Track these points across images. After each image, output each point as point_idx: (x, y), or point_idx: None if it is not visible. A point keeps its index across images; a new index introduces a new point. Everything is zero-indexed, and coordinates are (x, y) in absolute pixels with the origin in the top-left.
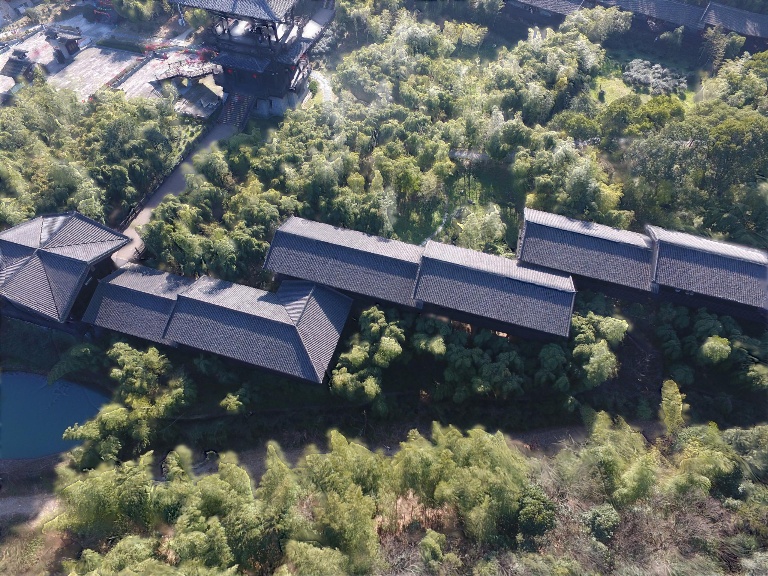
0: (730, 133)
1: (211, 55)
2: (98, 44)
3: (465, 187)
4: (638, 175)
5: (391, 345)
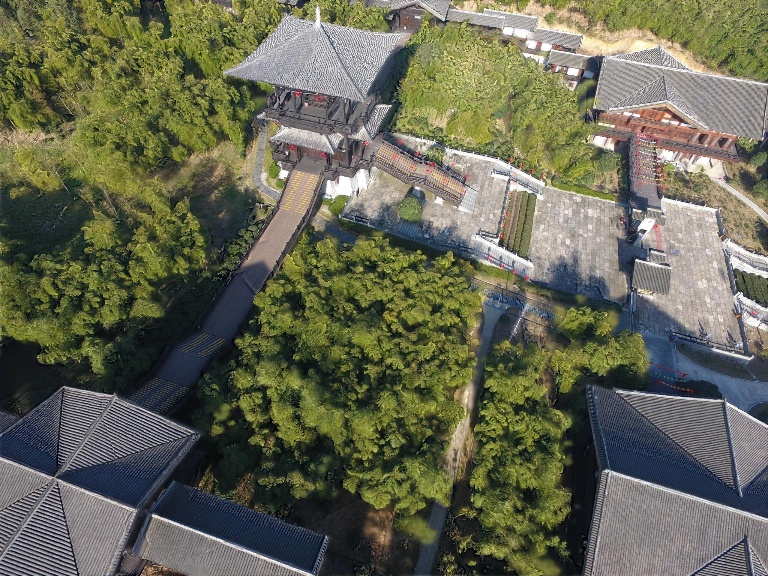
0: None
1: None
2: (617, 306)
3: None
4: None
5: None
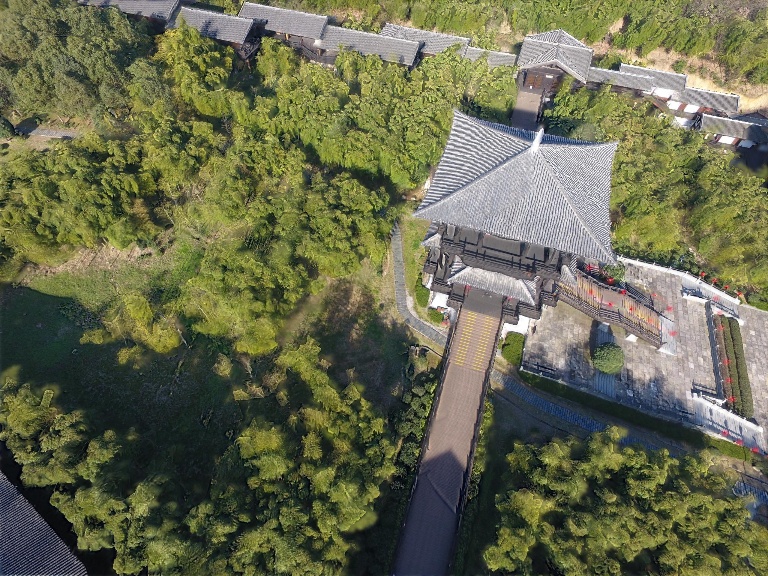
0: (52, 7)
1: (603, 345)
2: None
3: (263, 131)
4: (142, 34)
5: (351, 12)
